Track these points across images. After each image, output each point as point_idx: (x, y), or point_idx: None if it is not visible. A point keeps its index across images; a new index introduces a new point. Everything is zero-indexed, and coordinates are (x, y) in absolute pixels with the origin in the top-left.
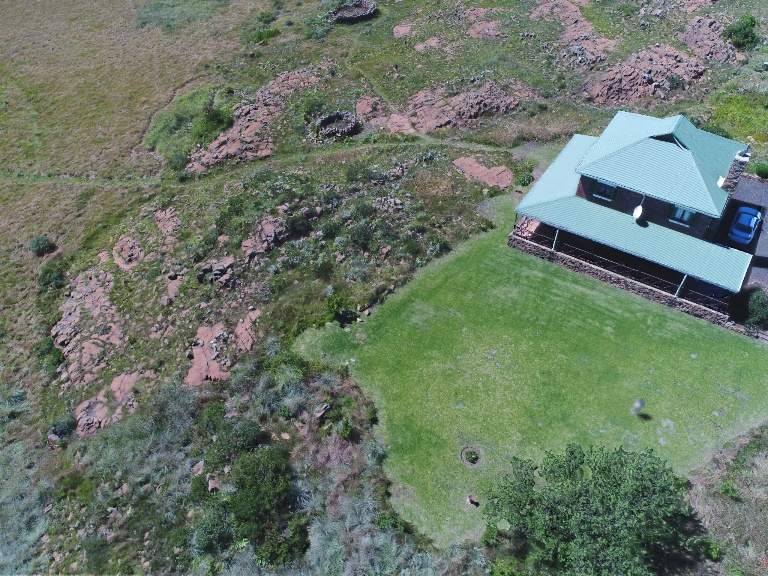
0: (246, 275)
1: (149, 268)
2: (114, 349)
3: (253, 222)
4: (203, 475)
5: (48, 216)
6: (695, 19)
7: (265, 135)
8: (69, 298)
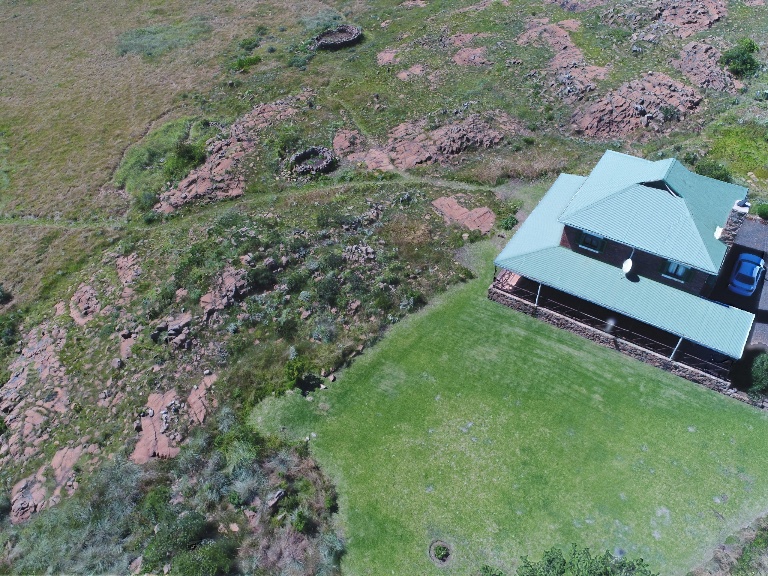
0: (203, 334)
1: (103, 324)
2: (58, 418)
3: (214, 274)
4: (140, 575)
5: (6, 262)
6: (690, 45)
7: (236, 173)
8: (20, 356)
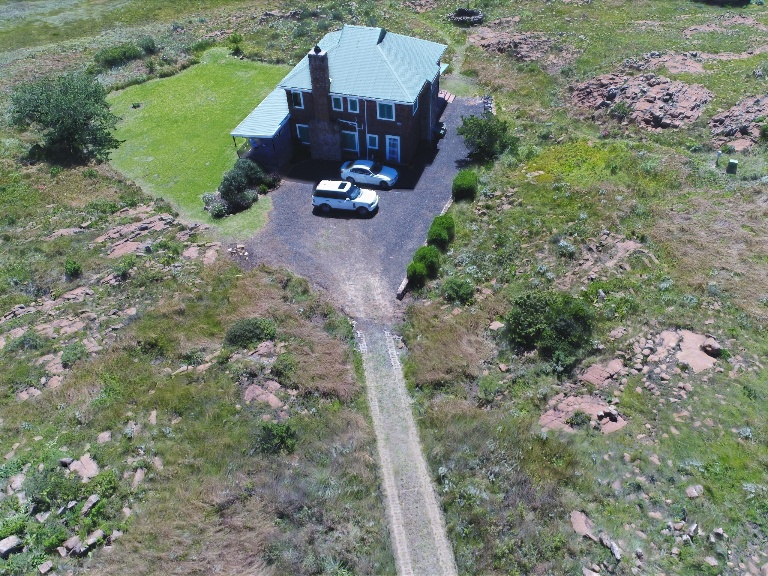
0: (268, 22)
1: None
2: None
3: None
4: None
5: None
6: None
7: (437, 2)
8: None
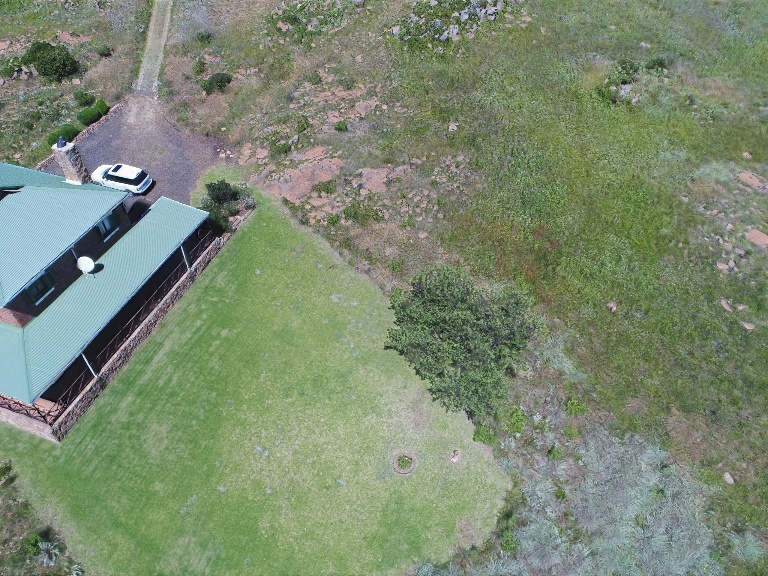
0: None
1: None
2: None
3: None
4: None
5: None
6: None
7: None
8: None
